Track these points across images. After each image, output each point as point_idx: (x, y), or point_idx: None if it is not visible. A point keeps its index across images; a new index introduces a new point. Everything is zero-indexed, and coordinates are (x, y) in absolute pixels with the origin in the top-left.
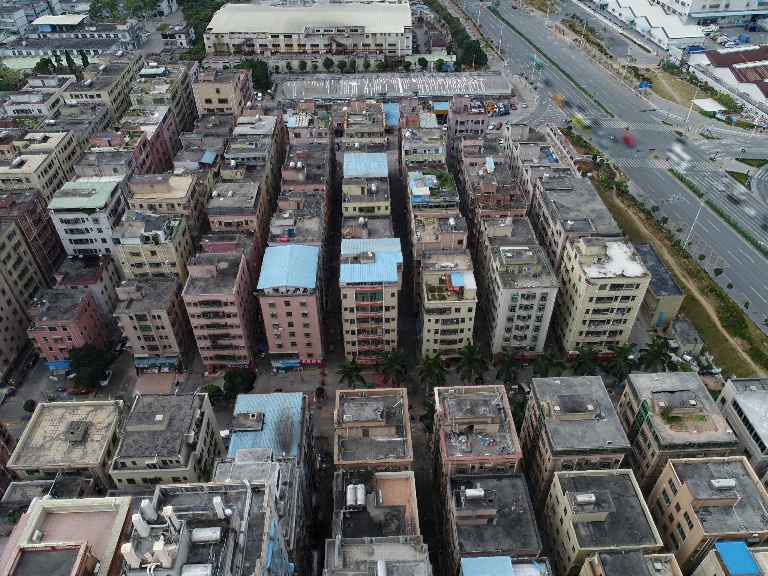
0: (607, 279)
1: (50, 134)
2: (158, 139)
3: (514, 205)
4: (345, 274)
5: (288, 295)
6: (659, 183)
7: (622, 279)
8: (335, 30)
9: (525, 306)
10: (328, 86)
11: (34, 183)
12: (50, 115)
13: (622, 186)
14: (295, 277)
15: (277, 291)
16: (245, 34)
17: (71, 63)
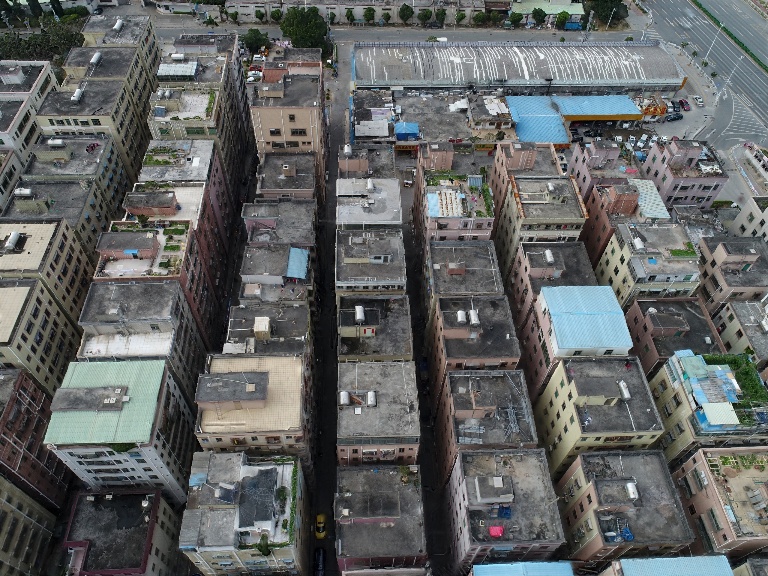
0: None
1: (27, 228)
2: (204, 213)
3: None
4: None
5: None
6: None
7: None
8: None
9: None
10: (420, 63)
11: (11, 357)
12: (17, 146)
13: None
14: None
15: None
16: None
17: (33, 3)
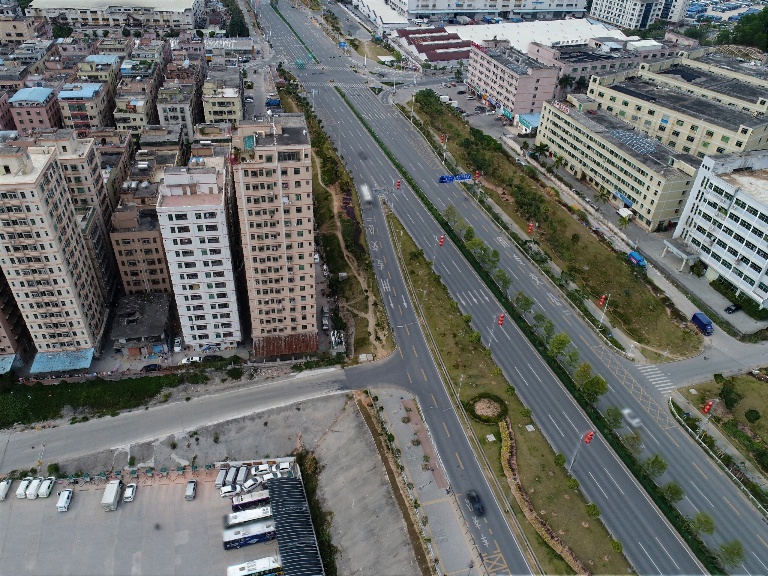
0: (214, 98)
1: None
2: None
3: (186, 76)
4: (61, 94)
5: (28, 107)
6: (323, 92)
7: (222, 99)
8: (133, 10)
9: (173, 117)
10: None
11: None
12: None
13: (292, 90)
14: (32, 97)
15: (21, 105)
16: (59, 10)
17: None
